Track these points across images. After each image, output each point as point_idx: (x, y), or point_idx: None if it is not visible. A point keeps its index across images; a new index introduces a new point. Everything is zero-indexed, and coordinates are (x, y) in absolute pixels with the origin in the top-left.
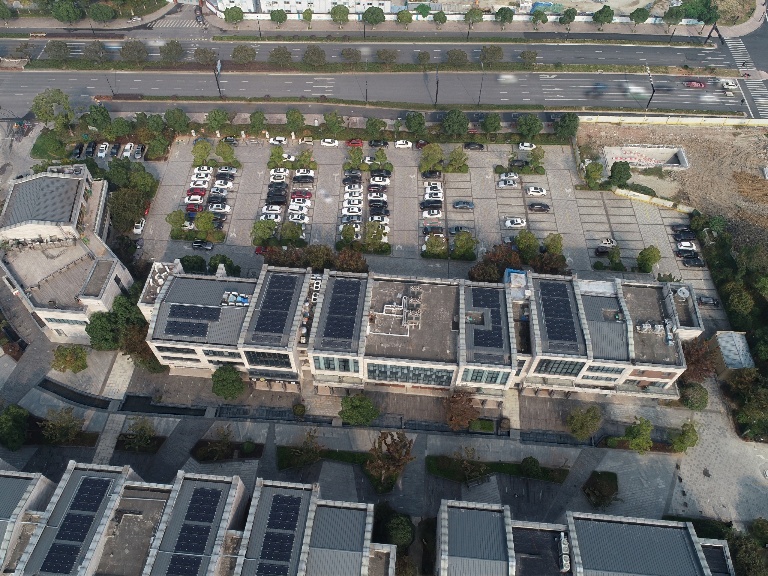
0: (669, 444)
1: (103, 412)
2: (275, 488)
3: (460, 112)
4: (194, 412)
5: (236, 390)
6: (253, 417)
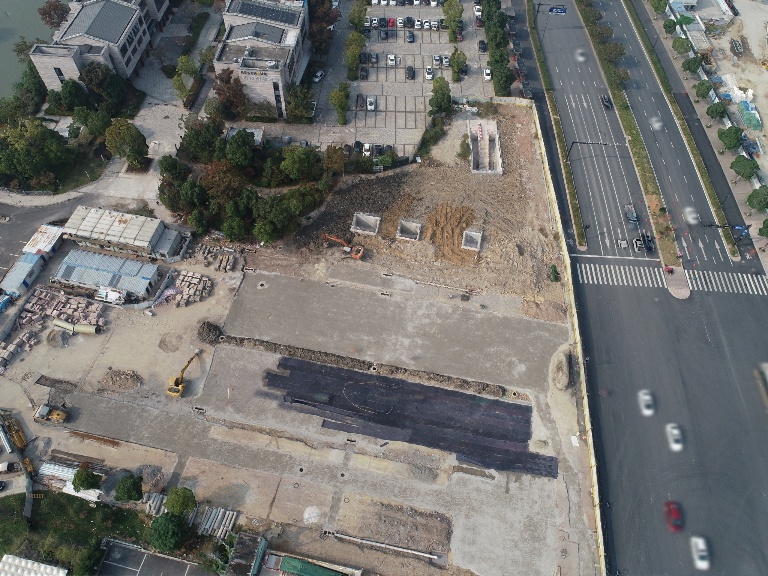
0: (191, 104)
1: None
2: None
3: (498, 12)
4: None
5: None
6: None
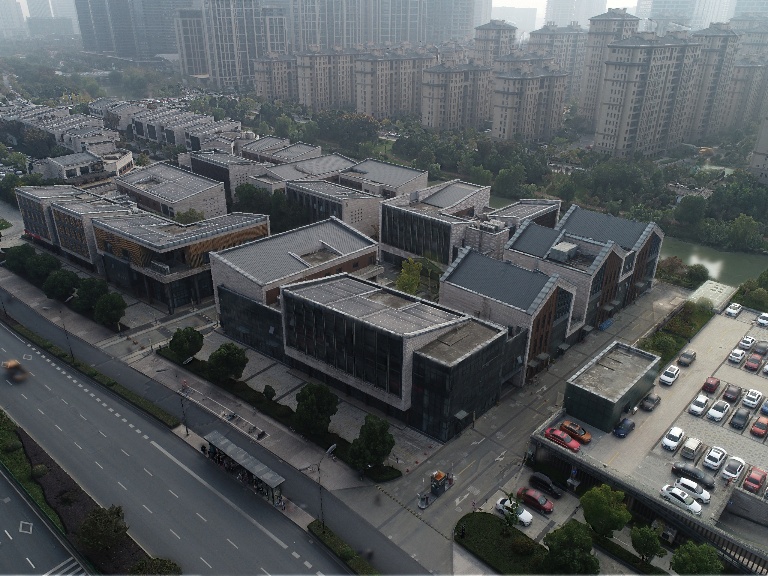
0: None
1: None
2: None
3: None
4: None
5: None
6: None
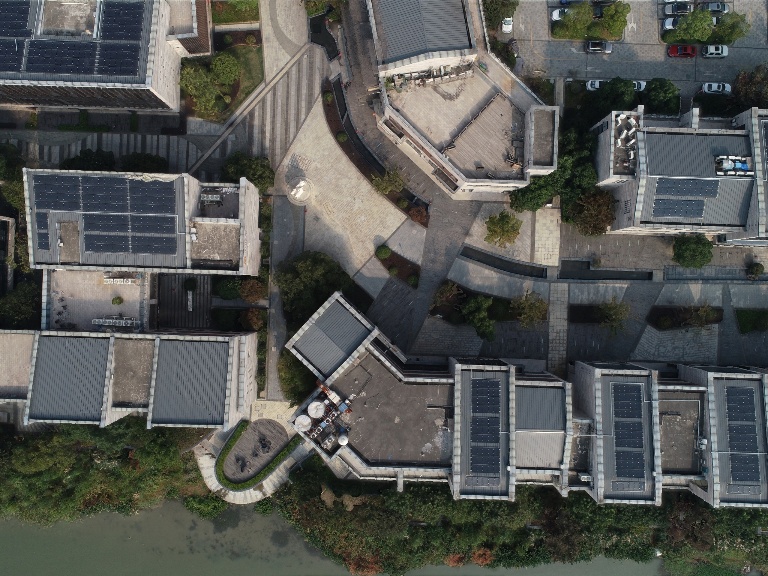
0: None
1: (543, 282)
2: None
3: None
4: (637, 275)
5: (706, 261)
6: (702, 277)
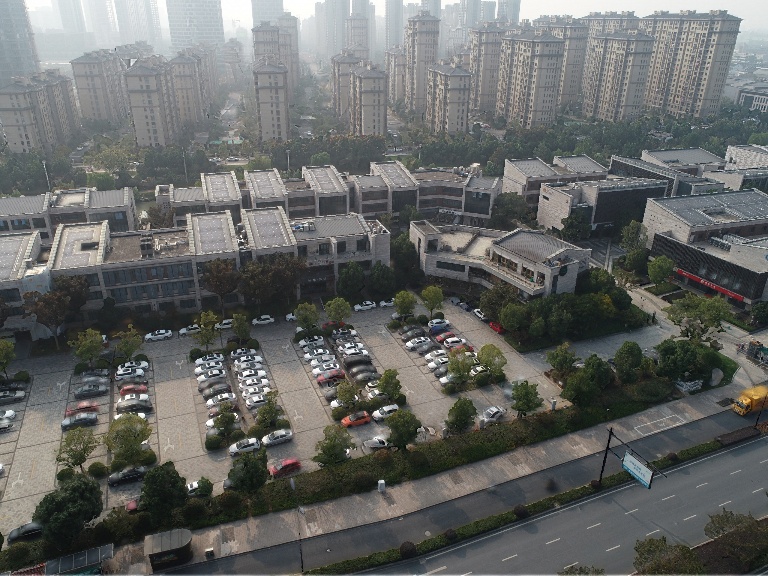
0: None
1: None
2: (231, 199)
3: (54, 493)
4: None
5: None
6: None
